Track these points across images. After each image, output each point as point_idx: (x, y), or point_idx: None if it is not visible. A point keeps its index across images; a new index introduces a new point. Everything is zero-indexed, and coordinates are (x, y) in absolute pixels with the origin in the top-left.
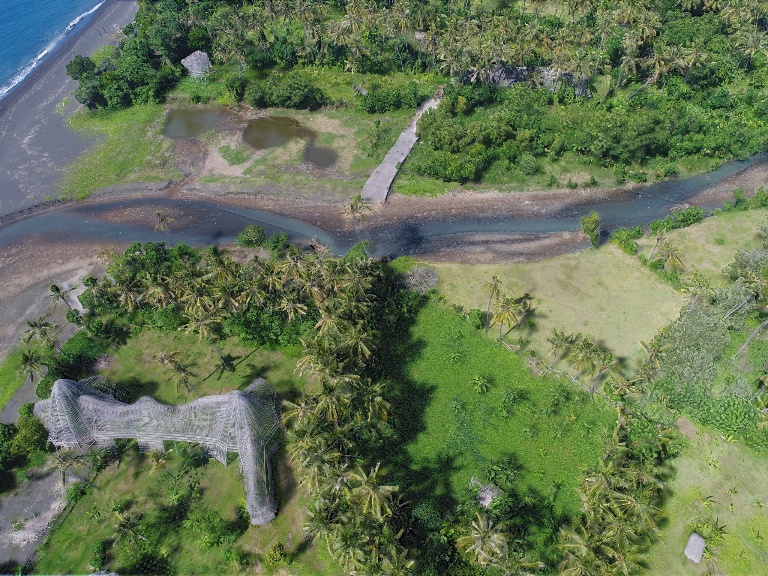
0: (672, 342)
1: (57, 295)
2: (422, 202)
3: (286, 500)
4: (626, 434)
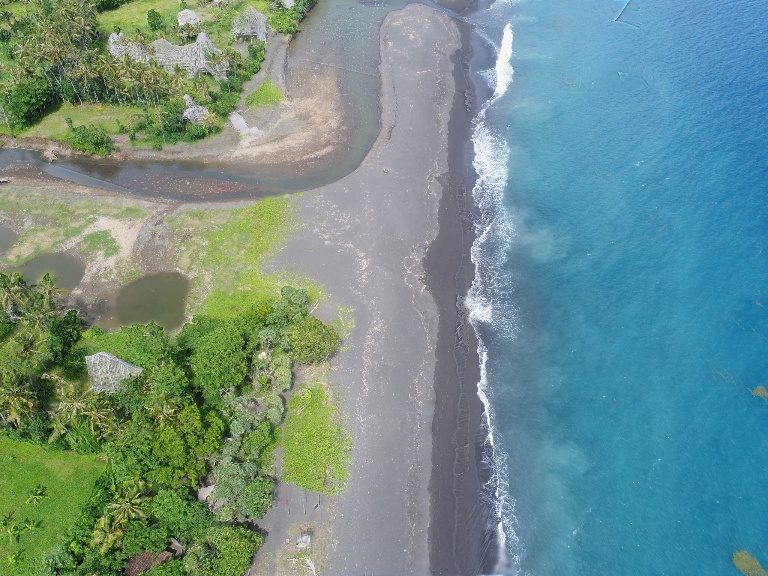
0: None
1: None
2: None
3: None
4: None
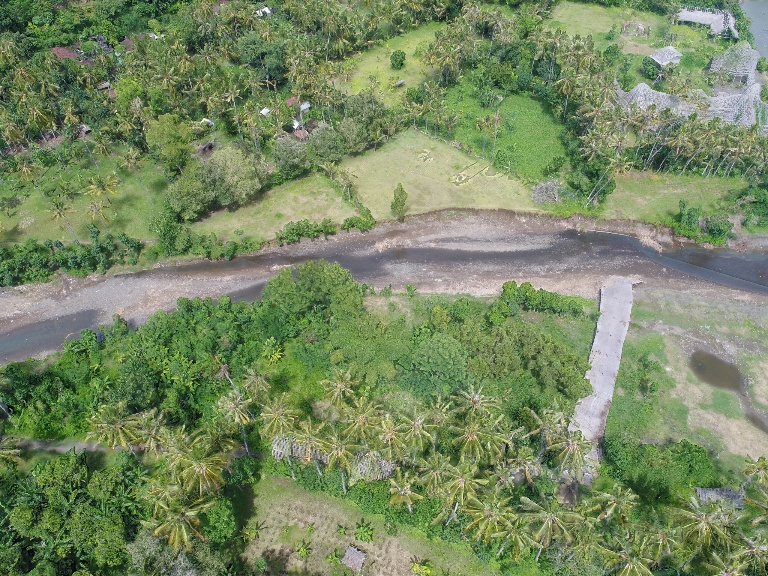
0: None
1: None
2: (557, 287)
3: None
4: None
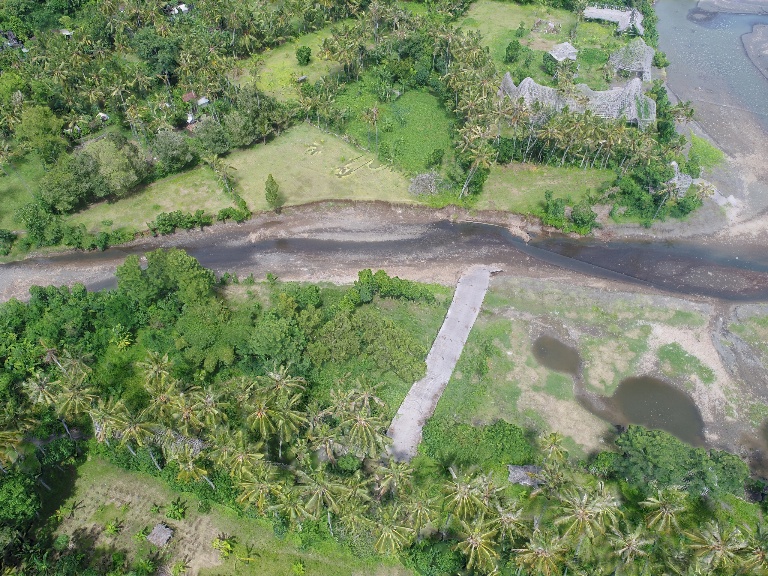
0: (268, 110)
1: (687, 112)
2: (419, 275)
3: (494, 99)
4: None
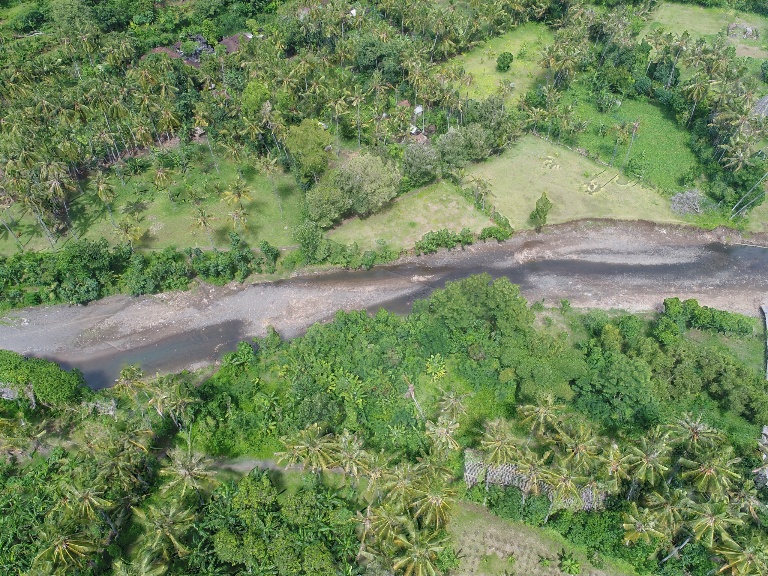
0: None
1: None
2: (714, 303)
3: None
4: (530, 123)
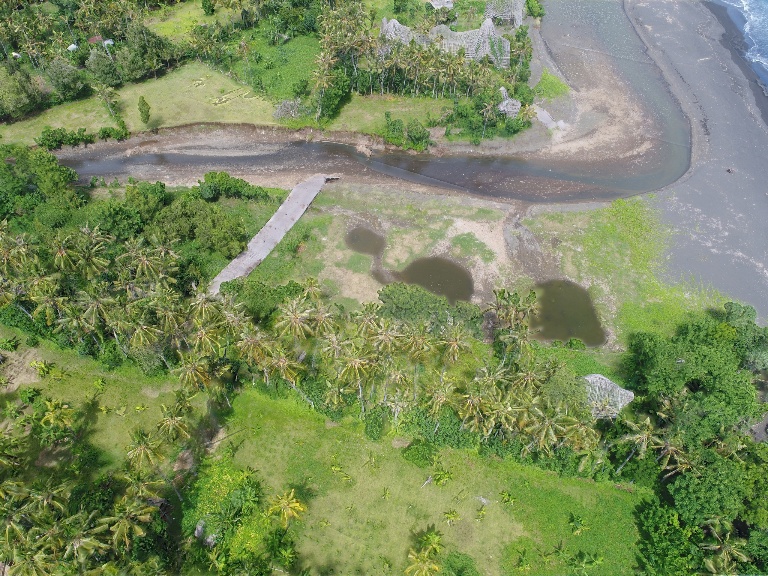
0: None
1: (521, 45)
2: (266, 181)
3: None
4: None
